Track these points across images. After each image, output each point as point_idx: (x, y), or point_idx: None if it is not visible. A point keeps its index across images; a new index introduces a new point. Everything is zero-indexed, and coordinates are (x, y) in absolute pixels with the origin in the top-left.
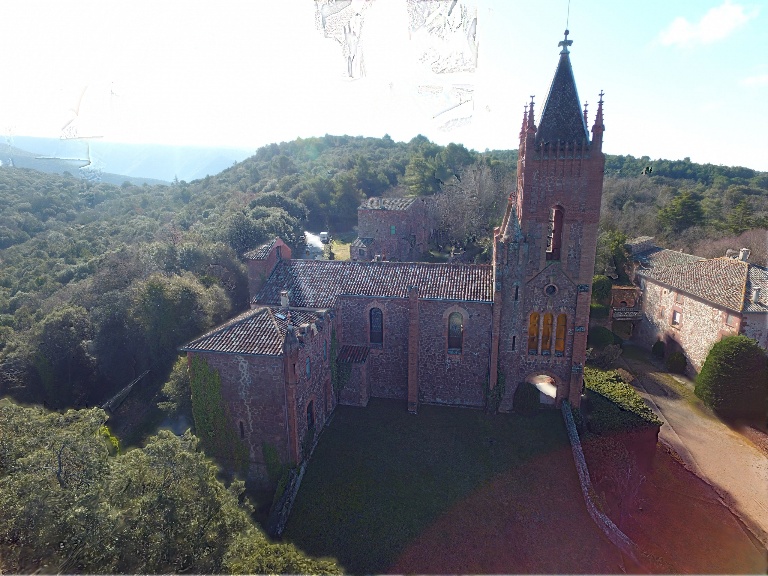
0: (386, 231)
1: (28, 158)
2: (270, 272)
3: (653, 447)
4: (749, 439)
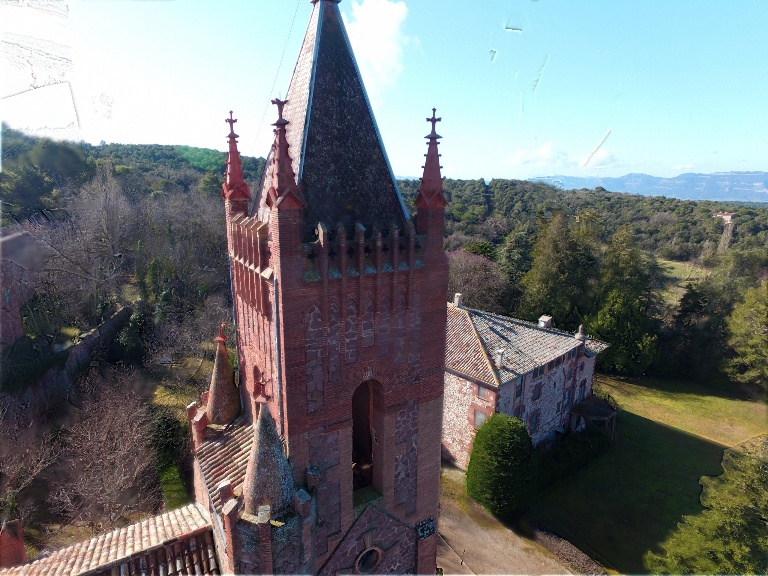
0: None
1: None
2: None
3: None
4: (542, 546)
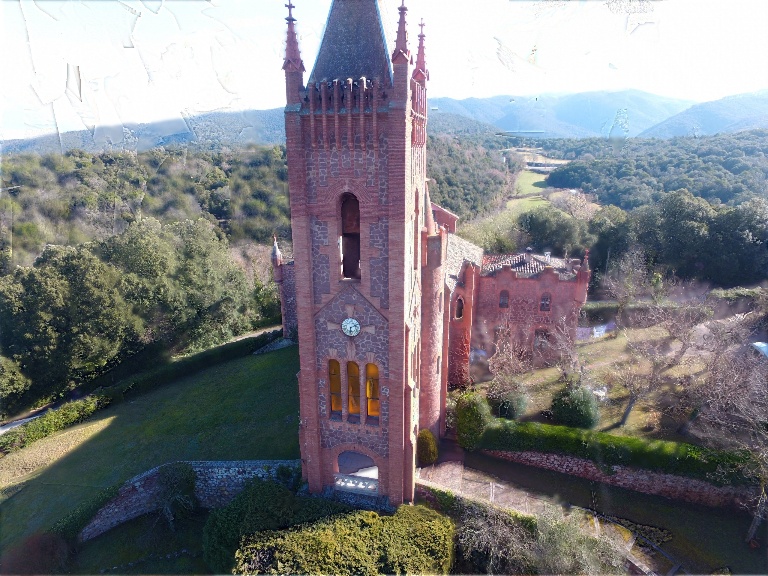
0: None
1: (493, 133)
2: None
3: None
4: None
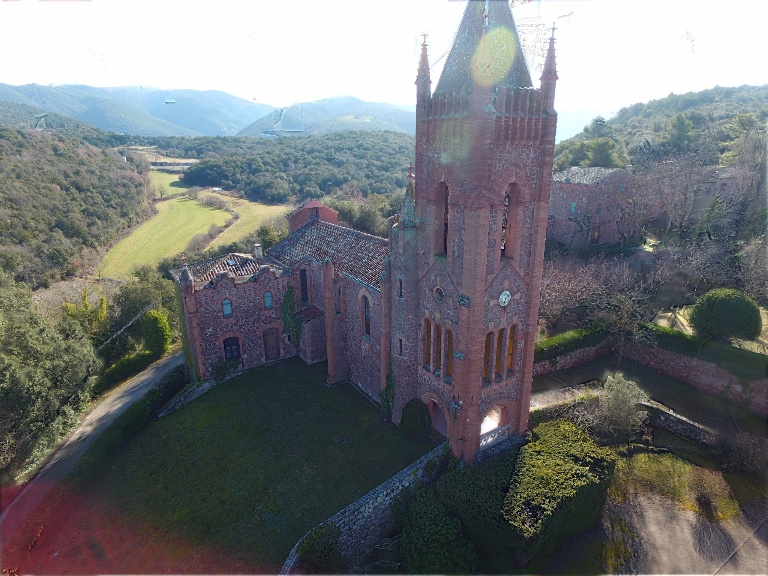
0: (567, 208)
1: (259, 131)
2: (296, 229)
3: (519, 563)
4: None
